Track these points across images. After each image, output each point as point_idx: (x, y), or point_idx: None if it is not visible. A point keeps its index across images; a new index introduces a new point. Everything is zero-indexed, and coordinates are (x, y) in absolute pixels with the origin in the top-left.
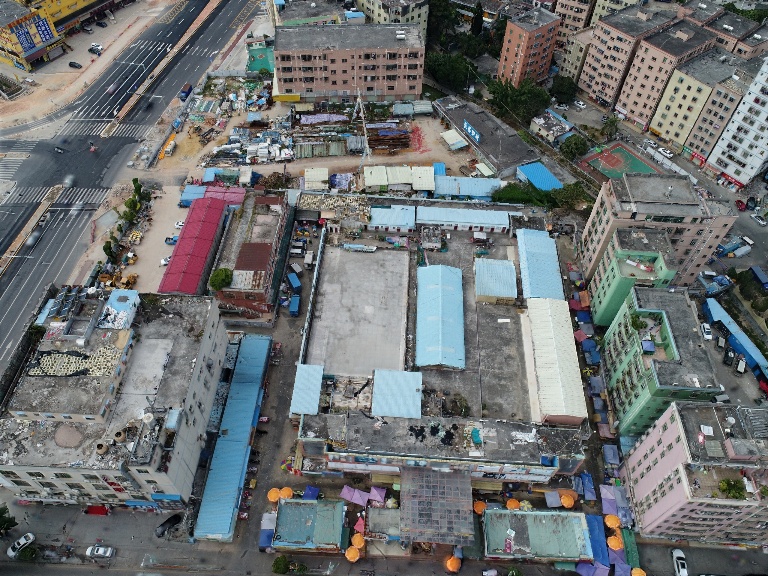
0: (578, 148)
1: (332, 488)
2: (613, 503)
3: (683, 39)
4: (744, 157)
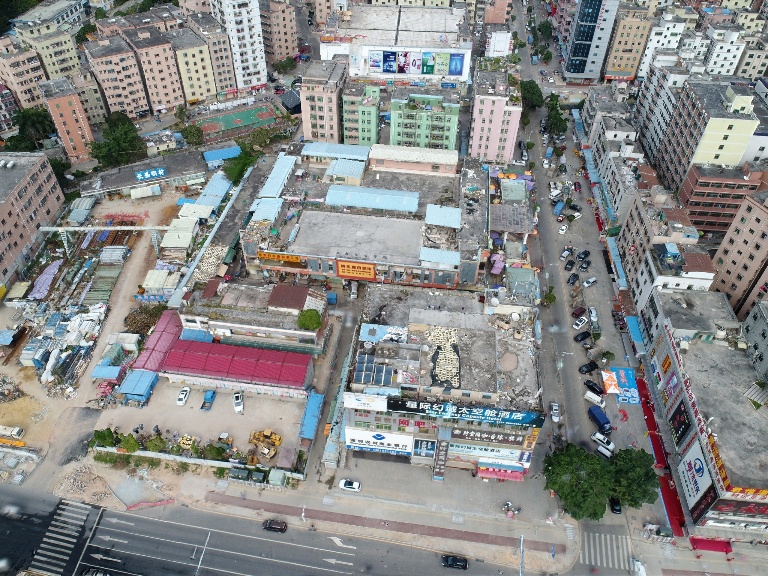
0: (199, 131)
1: (490, 284)
2: (491, 173)
3: (148, 37)
4: (255, 68)
